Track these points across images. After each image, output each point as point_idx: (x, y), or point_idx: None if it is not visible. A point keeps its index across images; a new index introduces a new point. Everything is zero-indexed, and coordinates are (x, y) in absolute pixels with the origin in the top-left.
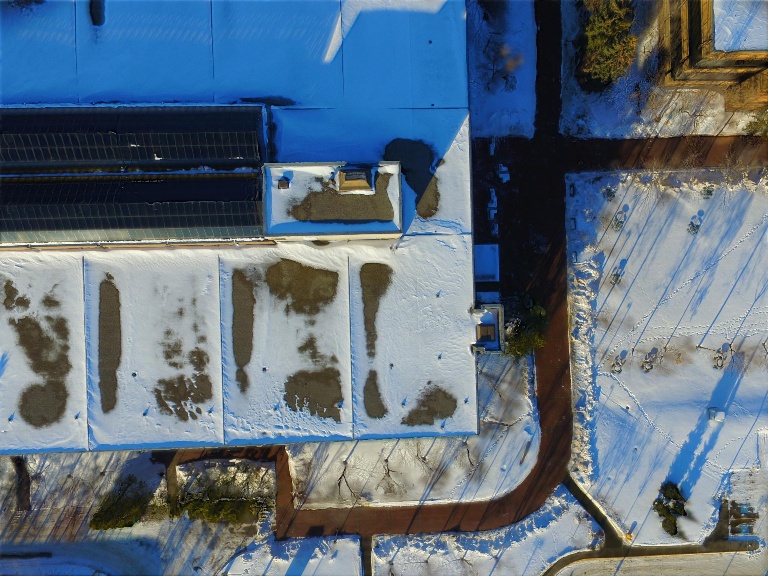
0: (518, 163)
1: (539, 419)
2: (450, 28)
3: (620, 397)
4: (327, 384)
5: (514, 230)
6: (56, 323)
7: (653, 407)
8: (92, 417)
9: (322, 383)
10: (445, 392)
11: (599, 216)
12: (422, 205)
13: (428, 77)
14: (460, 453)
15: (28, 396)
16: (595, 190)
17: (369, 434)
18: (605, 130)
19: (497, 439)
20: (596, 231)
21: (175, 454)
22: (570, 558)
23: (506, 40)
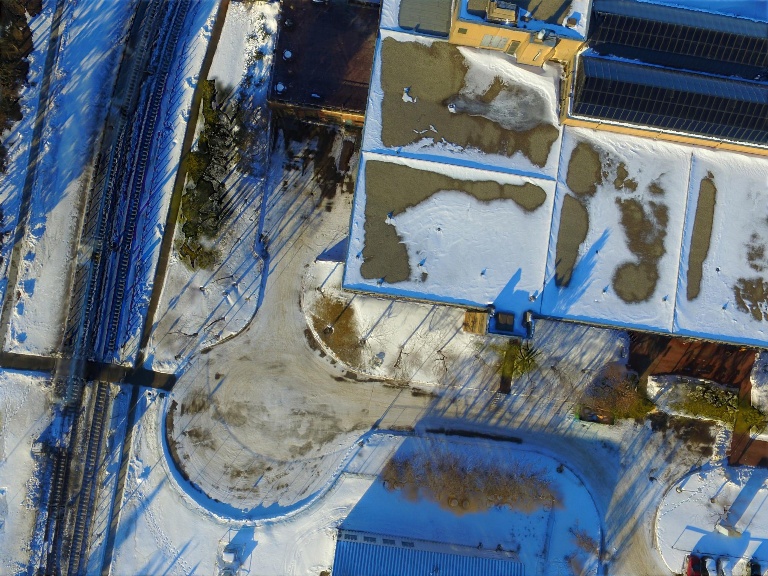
0: None
1: None
2: None
3: None
4: None
5: None
6: (658, 209)
7: None
8: (679, 302)
9: None
10: None
11: None
12: None
13: None
14: None
15: (622, 272)
16: None
17: None
18: None
19: None
20: None
21: (650, 365)
22: None
23: None
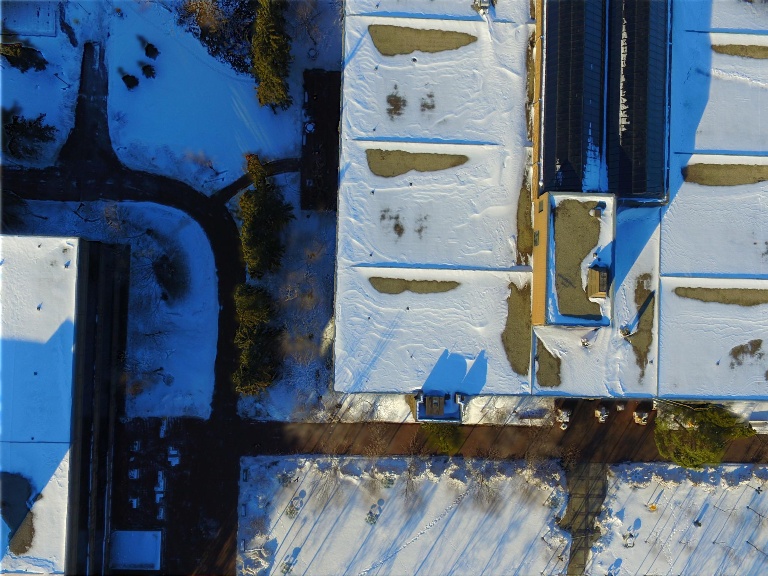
0: (191, 444)
1: None
2: (57, 360)
3: None
4: None
5: (183, 513)
6: None
7: None
8: None
9: None
10: None
11: (273, 502)
12: (15, 541)
13: (30, 410)
14: None
15: None
16: (270, 475)
17: None
18: (284, 414)
19: None
20: (270, 517)
21: None
22: None
23: (184, 320)
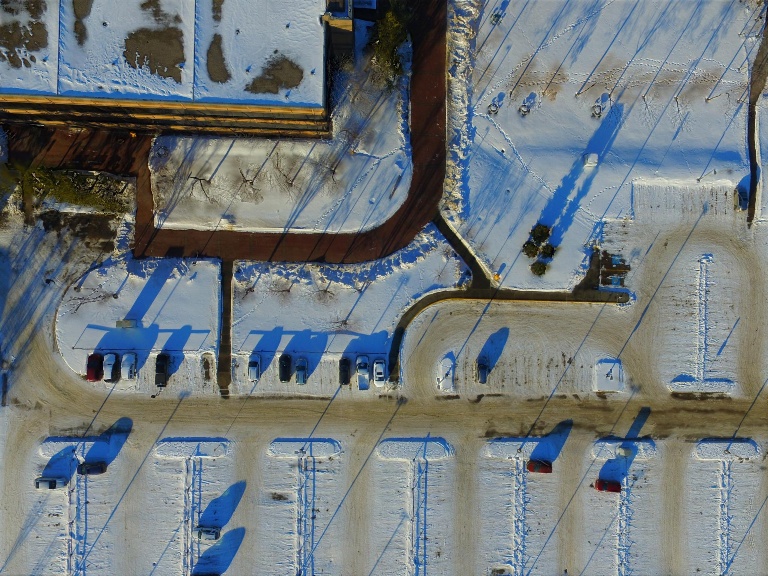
0: None
1: (412, 155)
2: None
3: (495, 139)
4: (169, 44)
5: None
6: None
7: (528, 151)
8: None
9: (164, 42)
10: (292, 62)
11: None
12: None
13: None
14: (328, 181)
15: None
16: None
17: (210, 97)
18: None
19: (367, 171)
20: None
21: (32, 161)
22: (436, 296)
23: None
